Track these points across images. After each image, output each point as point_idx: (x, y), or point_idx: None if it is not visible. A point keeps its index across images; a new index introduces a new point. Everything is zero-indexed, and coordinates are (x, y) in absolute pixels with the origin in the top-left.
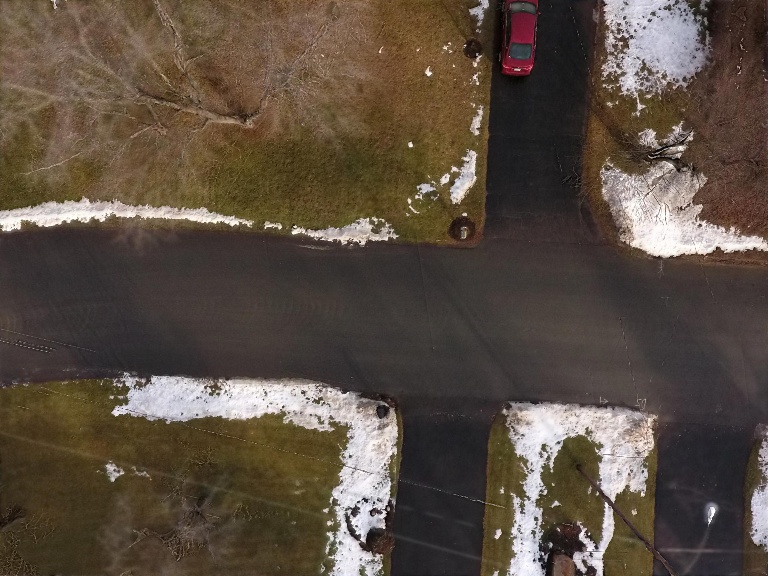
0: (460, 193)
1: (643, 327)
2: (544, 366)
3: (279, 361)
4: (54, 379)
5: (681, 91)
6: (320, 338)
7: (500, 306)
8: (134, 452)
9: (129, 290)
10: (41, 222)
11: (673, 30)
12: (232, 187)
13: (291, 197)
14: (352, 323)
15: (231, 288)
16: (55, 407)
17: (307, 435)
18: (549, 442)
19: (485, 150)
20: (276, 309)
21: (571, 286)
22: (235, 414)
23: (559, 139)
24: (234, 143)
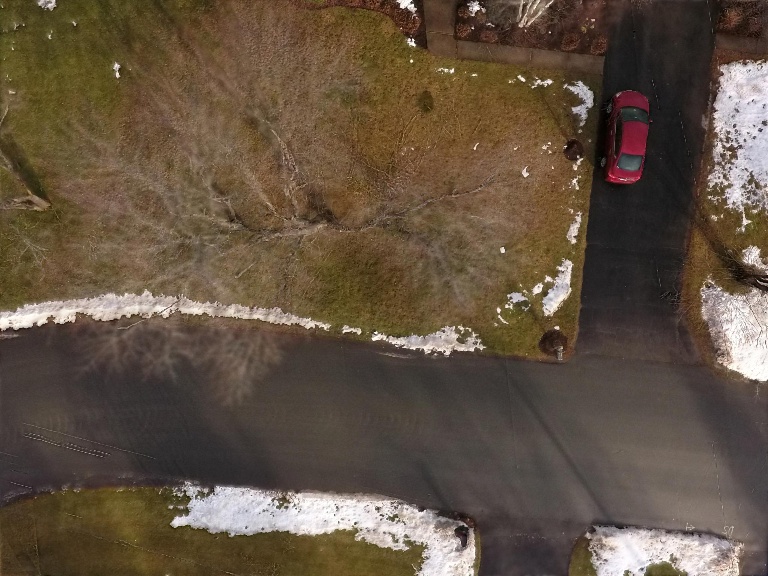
0: (554, 305)
1: (735, 453)
2: (631, 489)
3: (353, 475)
4: (108, 486)
5: None
6: (398, 452)
7: (589, 425)
8: (193, 566)
9: (193, 393)
10: (98, 316)
11: None
12: (309, 287)
13: (373, 301)
14: (433, 438)
15: (304, 396)
16: (108, 516)
17: (380, 554)
18: (632, 568)
19: (582, 260)
20: (352, 420)
21: (664, 407)
22: (304, 530)
23: (659, 252)
24: (314, 240)
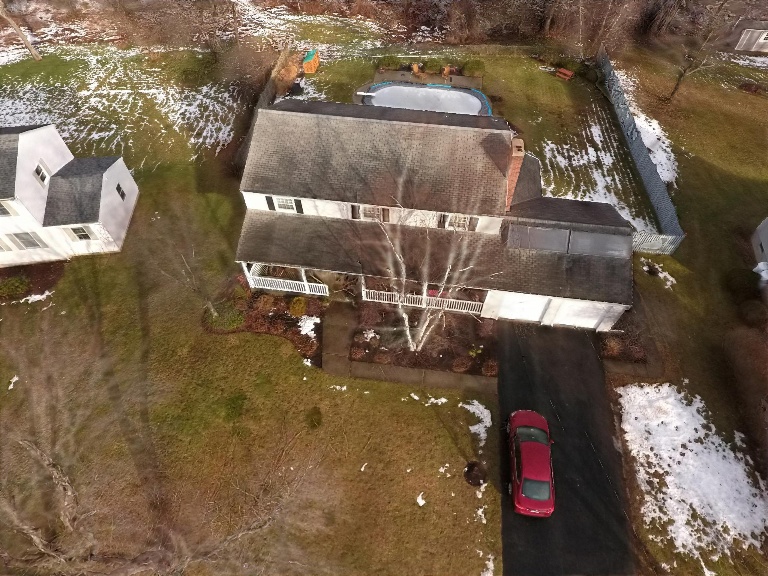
0: None
1: None
2: None
3: None
4: None
5: (756, 553)
6: None
7: None
8: None
9: None
10: None
11: (715, 468)
12: None
13: None
14: None
15: None
16: None
17: None
18: None
19: None
20: None
21: None
22: None
23: None
24: None
